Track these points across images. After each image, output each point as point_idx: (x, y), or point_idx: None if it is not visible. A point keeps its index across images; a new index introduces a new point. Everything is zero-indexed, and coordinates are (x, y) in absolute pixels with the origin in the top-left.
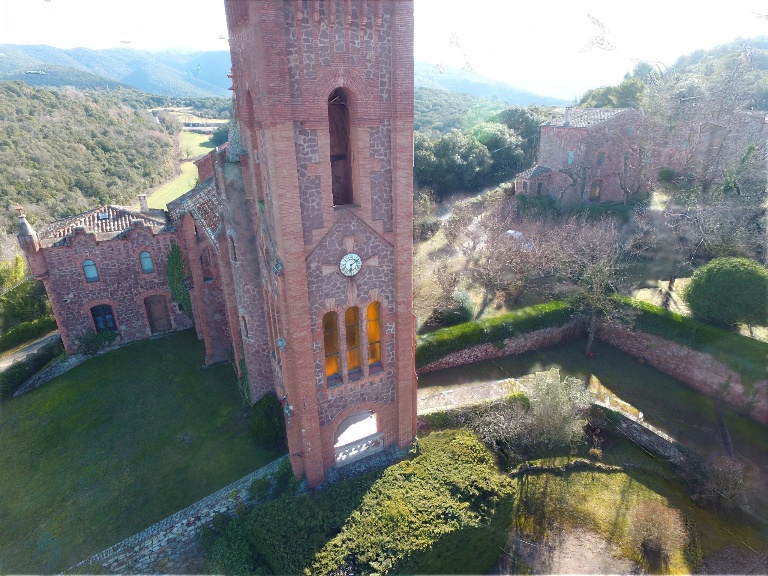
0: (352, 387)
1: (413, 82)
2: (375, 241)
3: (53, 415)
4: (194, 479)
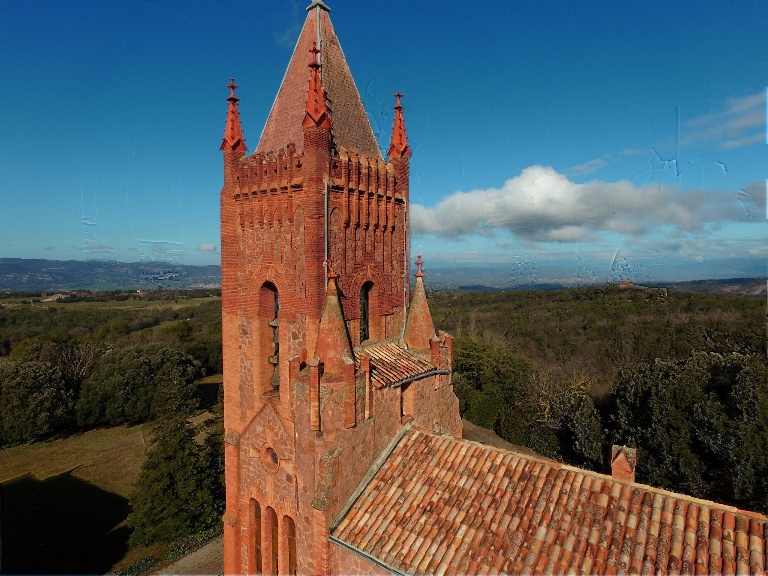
0: None
1: (223, 276)
2: None
3: None
4: None
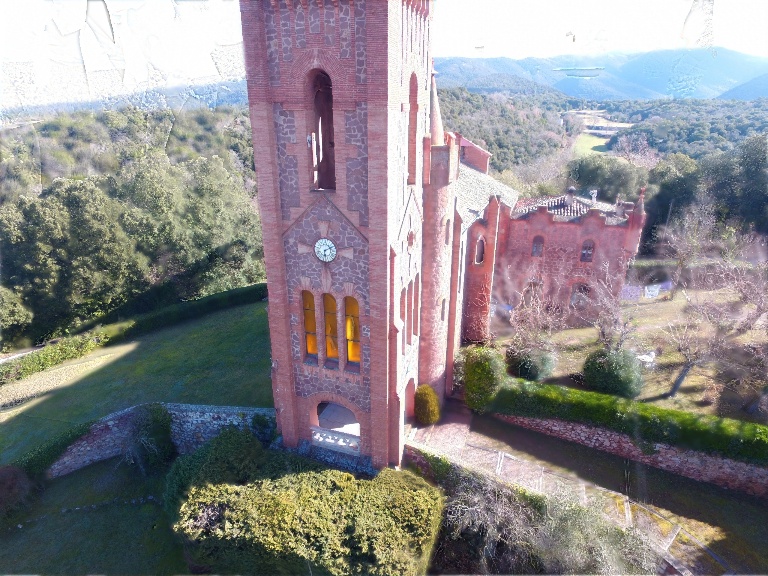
0: (327, 374)
1: (387, 59)
2: (351, 233)
3: (256, 318)
4: (253, 395)
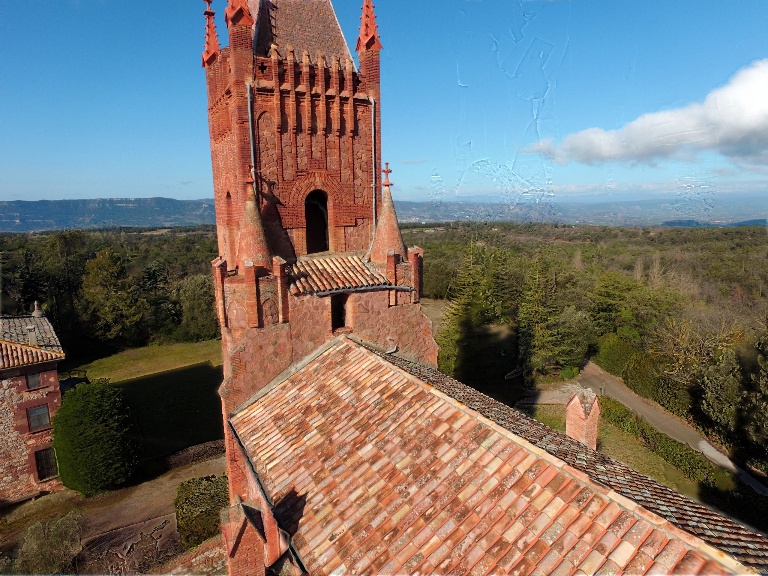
0: None
1: None
2: None
3: None
4: None
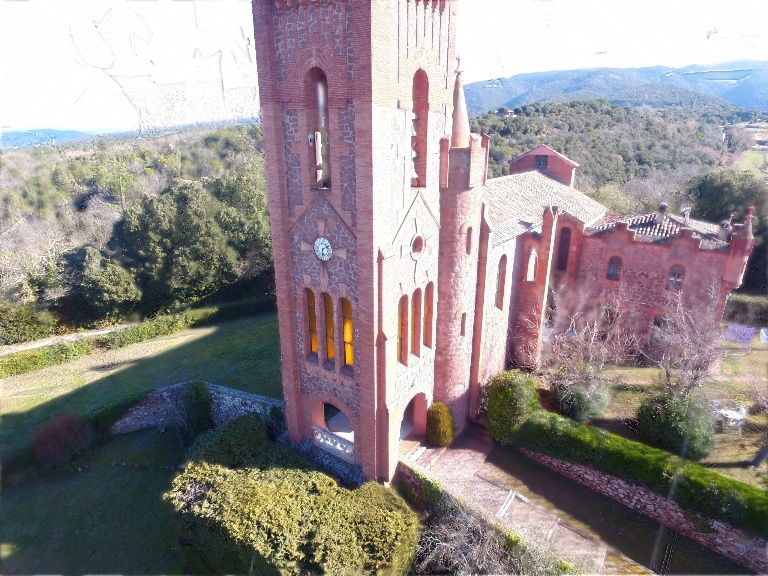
0: (326, 375)
1: (371, 53)
2: (345, 232)
3: None
4: None
